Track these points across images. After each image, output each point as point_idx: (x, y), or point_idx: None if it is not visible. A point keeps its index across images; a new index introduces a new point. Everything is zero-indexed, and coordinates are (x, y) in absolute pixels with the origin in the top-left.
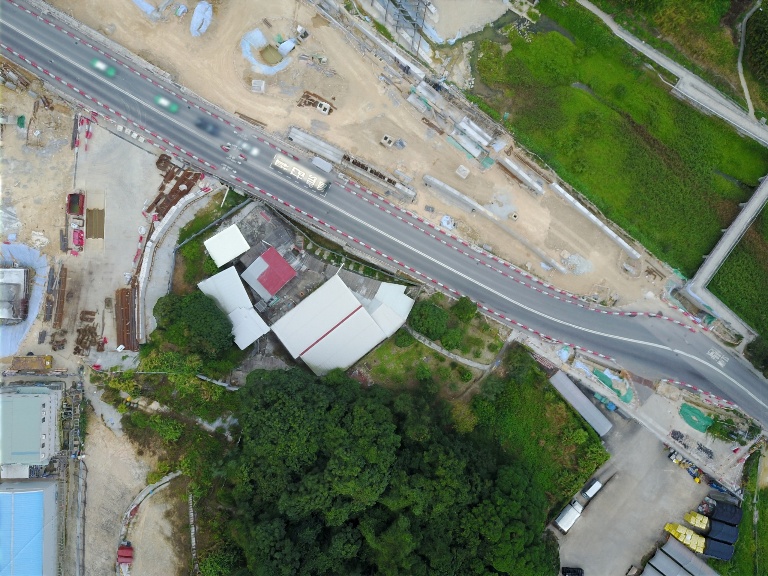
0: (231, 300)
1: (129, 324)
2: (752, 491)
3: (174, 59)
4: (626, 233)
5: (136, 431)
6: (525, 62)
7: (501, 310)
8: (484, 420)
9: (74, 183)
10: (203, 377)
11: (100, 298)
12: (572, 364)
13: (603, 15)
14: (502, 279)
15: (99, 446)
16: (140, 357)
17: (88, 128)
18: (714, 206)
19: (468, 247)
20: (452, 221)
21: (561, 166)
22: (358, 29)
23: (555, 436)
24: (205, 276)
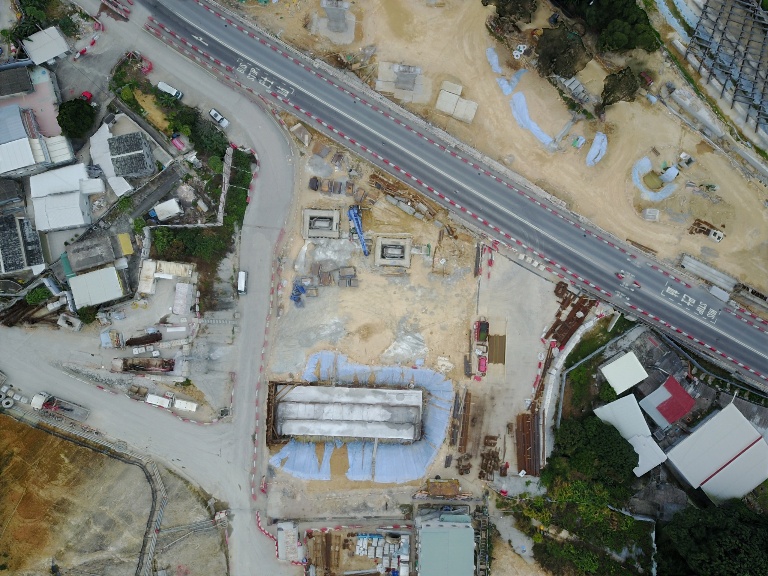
0: (628, 427)
1: (530, 449)
2: None
3: (569, 188)
4: None
5: None
6: None
7: None
8: None
9: (477, 310)
10: (610, 506)
11: (501, 423)
12: None
13: None
14: None
15: (509, 572)
16: (548, 485)
17: (491, 256)
18: None
19: None
20: None
21: None
22: (739, 154)
23: None
24: (600, 402)
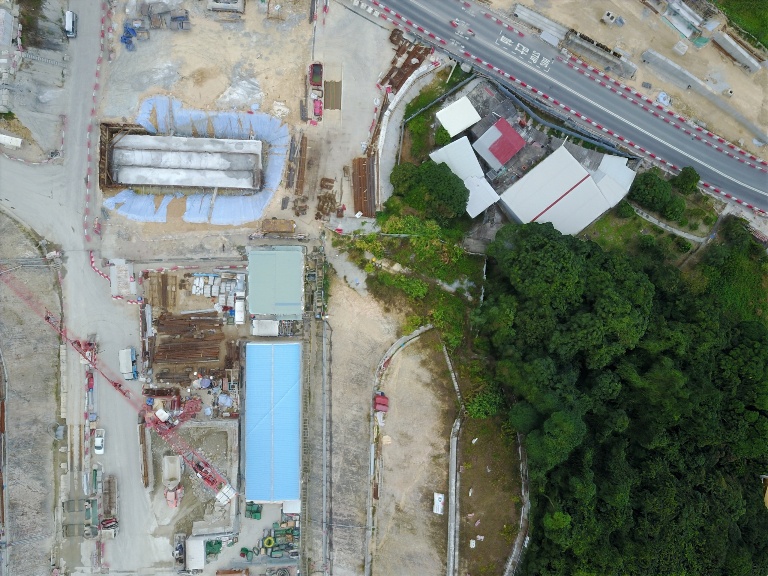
0: (463, 169)
1: (366, 192)
2: None
3: None
4: None
5: (381, 290)
6: None
7: (715, 185)
8: (711, 284)
9: (313, 56)
10: None
11: (338, 167)
12: None
13: None
14: (716, 154)
15: (344, 306)
16: (382, 221)
17: (326, 3)
18: None
19: (684, 123)
20: (668, 97)
21: None
22: None
23: None
24: (436, 147)
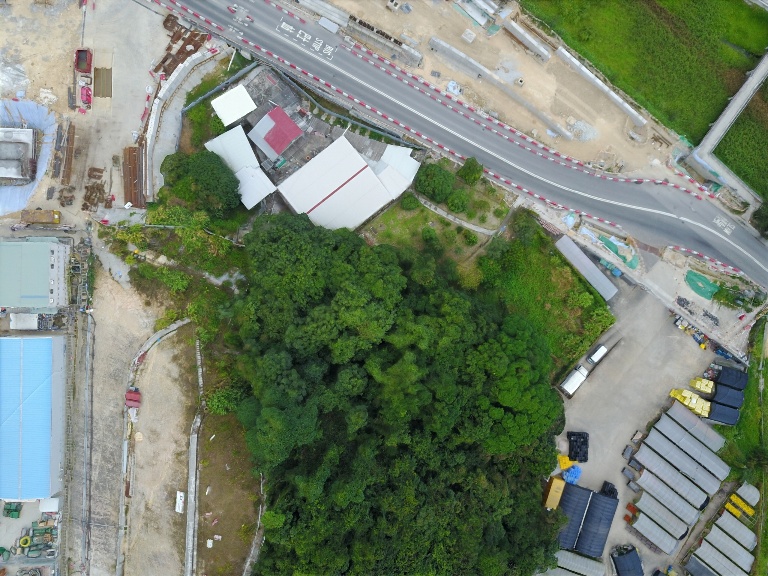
0: (238, 159)
1: (137, 182)
2: (758, 358)
3: None
4: (632, 100)
5: (144, 283)
6: None
7: (507, 176)
8: (490, 278)
9: (82, 42)
10: (210, 232)
11: (108, 156)
12: (578, 231)
13: None
14: (508, 145)
15: (107, 299)
16: (147, 212)
17: None
18: (721, 75)
19: (474, 112)
20: (458, 87)
21: (567, 34)
22: None
23: (560, 301)
24: (212, 137)
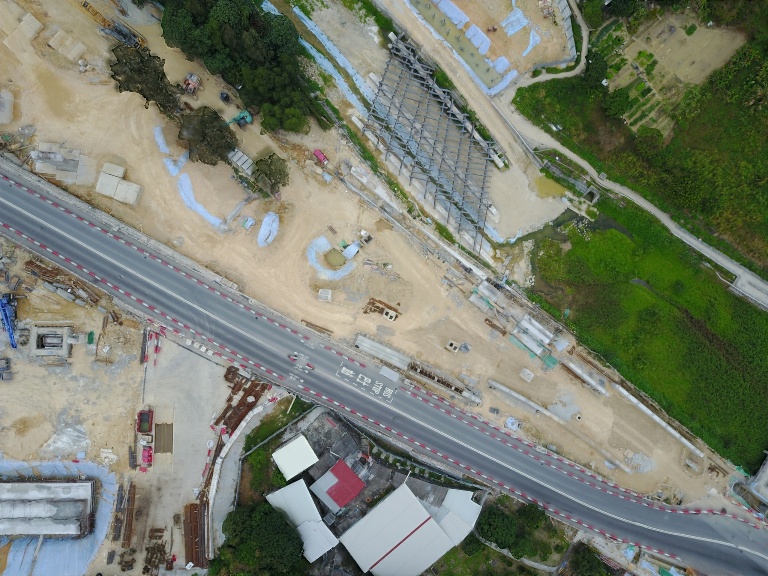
0: (300, 513)
1: (198, 541)
2: None
3: (241, 269)
4: (688, 430)
5: None
6: (585, 260)
7: (566, 510)
8: None
9: (143, 398)
10: None
11: (169, 514)
12: (638, 564)
13: (660, 213)
14: (567, 479)
15: None
16: None
17: (157, 343)
18: None
19: (533, 448)
20: (516, 422)
21: (622, 363)
22: (420, 230)
23: None
24: (273, 487)
